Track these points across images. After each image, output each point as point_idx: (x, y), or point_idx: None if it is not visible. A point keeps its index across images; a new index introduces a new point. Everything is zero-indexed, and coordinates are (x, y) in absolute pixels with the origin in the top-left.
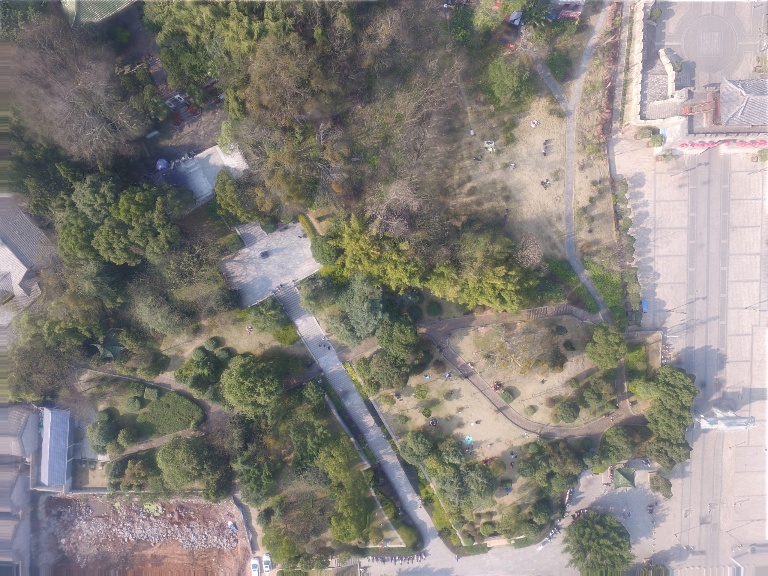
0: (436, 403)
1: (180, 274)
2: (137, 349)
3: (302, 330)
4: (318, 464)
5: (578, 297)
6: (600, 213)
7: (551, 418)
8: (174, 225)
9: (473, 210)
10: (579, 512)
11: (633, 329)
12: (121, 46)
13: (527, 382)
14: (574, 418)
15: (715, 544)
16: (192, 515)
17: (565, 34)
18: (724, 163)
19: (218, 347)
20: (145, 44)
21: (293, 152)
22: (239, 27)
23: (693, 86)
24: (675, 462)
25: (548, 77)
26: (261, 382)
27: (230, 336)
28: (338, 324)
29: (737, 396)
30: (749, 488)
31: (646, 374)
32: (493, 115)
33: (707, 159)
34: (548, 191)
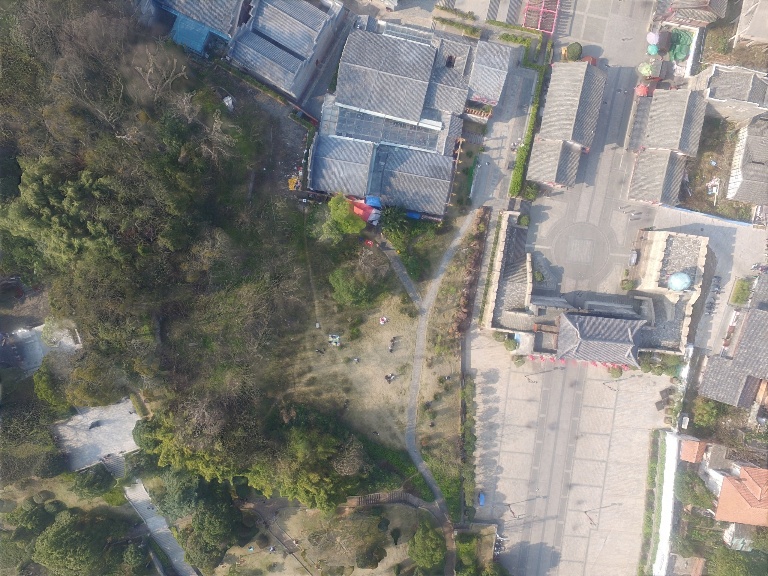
0: (259, 573)
1: (8, 437)
2: None
3: (130, 494)
4: None
5: (413, 487)
6: (445, 408)
7: None
8: None
9: (311, 399)
10: None
11: None
12: None
13: (350, 564)
14: None
15: None
16: None
17: (419, 243)
18: (581, 369)
19: (48, 499)
20: None
21: (95, 371)
22: (59, 242)
23: (558, 291)
24: None
25: (404, 275)
26: (71, 552)
27: (60, 492)
28: (154, 505)
29: None
30: None
31: (476, 564)
32: (341, 310)
33: (564, 364)
34: (392, 384)
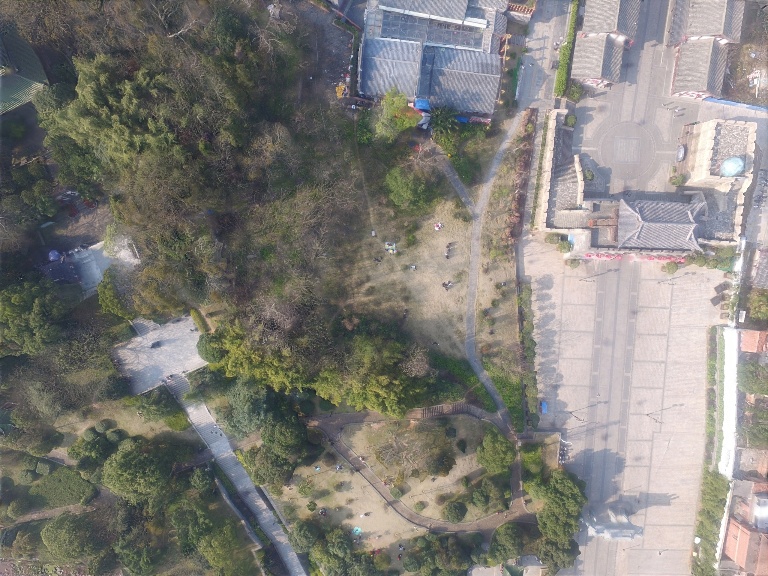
0: (326, 493)
1: (69, 361)
2: (28, 428)
3: (193, 417)
4: (199, 551)
5: (476, 397)
6: (503, 315)
7: (440, 515)
8: (52, 325)
9: (371, 309)
10: None
11: (533, 428)
12: (16, 140)
13: None
14: (458, 520)
15: None
16: None
17: (471, 142)
18: (634, 270)
19: (110, 428)
20: (42, 137)
21: (165, 268)
22: (121, 140)
23: (607, 192)
24: (560, 567)
25: (456, 180)
26: (141, 473)
27: (121, 419)
28: (222, 420)
29: (634, 500)
30: None
31: (542, 474)
32: (396, 217)
33: (617, 265)
34: (450, 292)
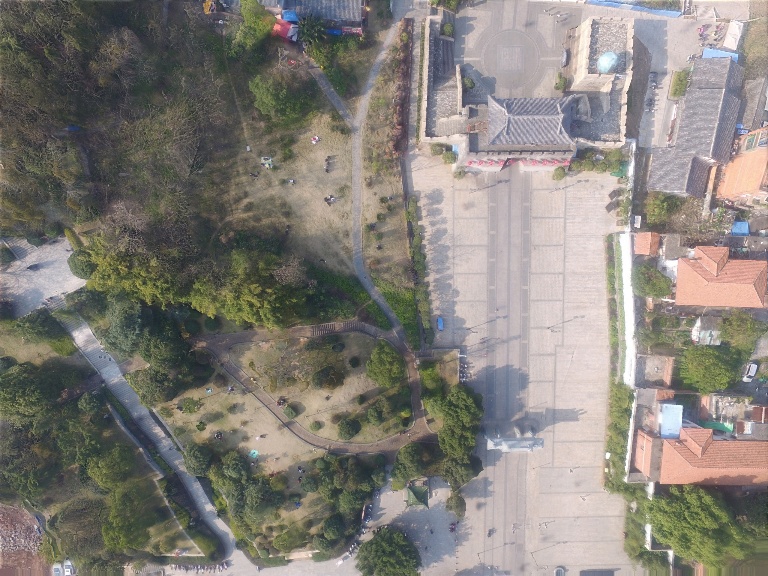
0: (220, 416)
1: None
2: None
3: (79, 341)
4: None
5: (367, 314)
6: (391, 230)
7: (337, 434)
8: None
9: (251, 226)
10: (380, 528)
11: (432, 346)
12: None
13: (312, 398)
14: (349, 435)
15: (520, 565)
16: (1, 518)
17: (340, 51)
18: (525, 181)
19: None
20: None
21: (10, 171)
22: None
23: None
24: (460, 482)
25: (331, 93)
26: (20, 393)
27: (8, 346)
28: (98, 337)
29: (540, 416)
30: (555, 510)
31: (442, 392)
32: (270, 131)
33: (507, 176)
34: (333, 207)
